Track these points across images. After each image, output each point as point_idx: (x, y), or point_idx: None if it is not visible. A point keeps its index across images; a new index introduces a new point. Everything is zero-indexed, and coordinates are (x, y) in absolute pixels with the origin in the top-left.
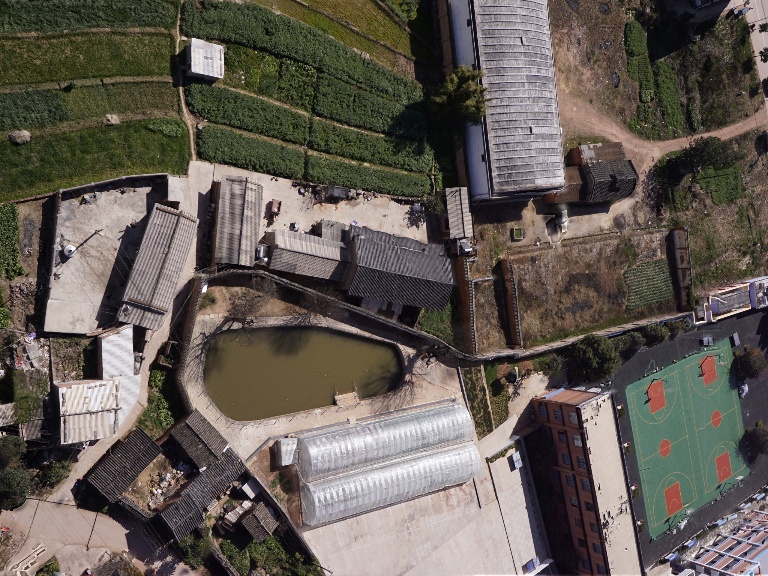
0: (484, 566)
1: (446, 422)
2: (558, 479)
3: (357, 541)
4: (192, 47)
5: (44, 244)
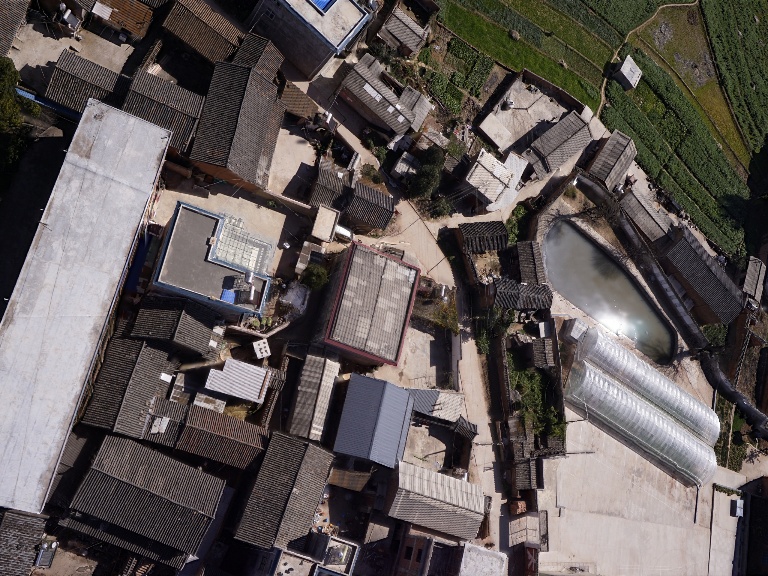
0: None
1: (701, 408)
2: None
3: (593, 450)
4: (626, 59)
5: (498, 92)
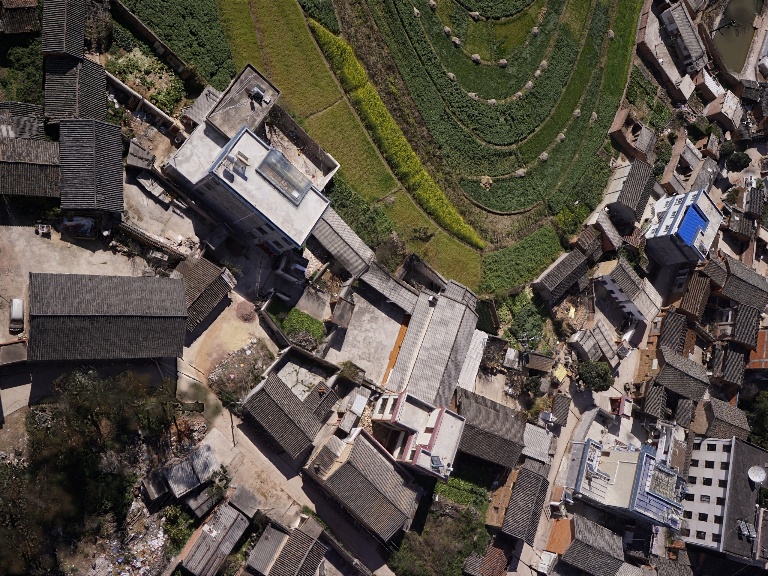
0: None
1: None
2: None
3: None
4: None
5: (651, 69)
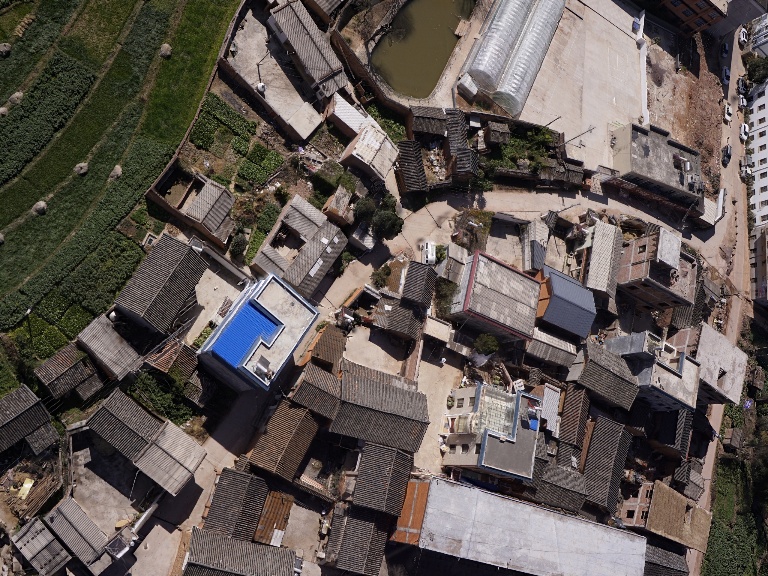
0: (614, 51)
1: None
2: None
3: (545, 100)
4: None
5: (246, 98)
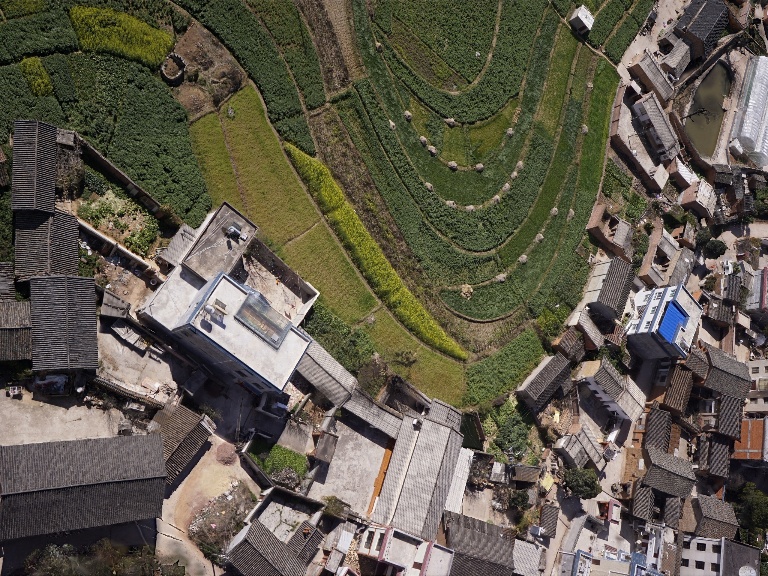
0: None
1: (766, 70)
2: None
3: None
4: (581, 19)
5: (626, 161)
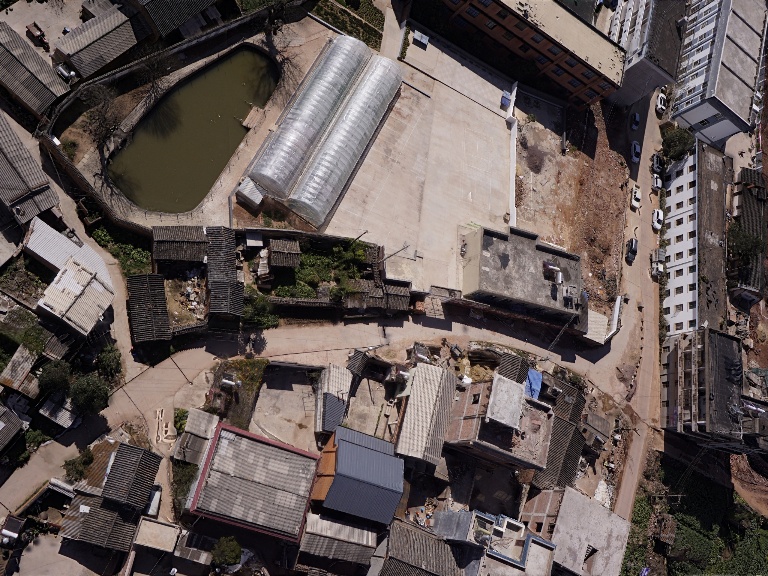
0: (473, 134)
1: (339, 58)
2: (464, 22)
3: (367, 203)
4: None
5: None
